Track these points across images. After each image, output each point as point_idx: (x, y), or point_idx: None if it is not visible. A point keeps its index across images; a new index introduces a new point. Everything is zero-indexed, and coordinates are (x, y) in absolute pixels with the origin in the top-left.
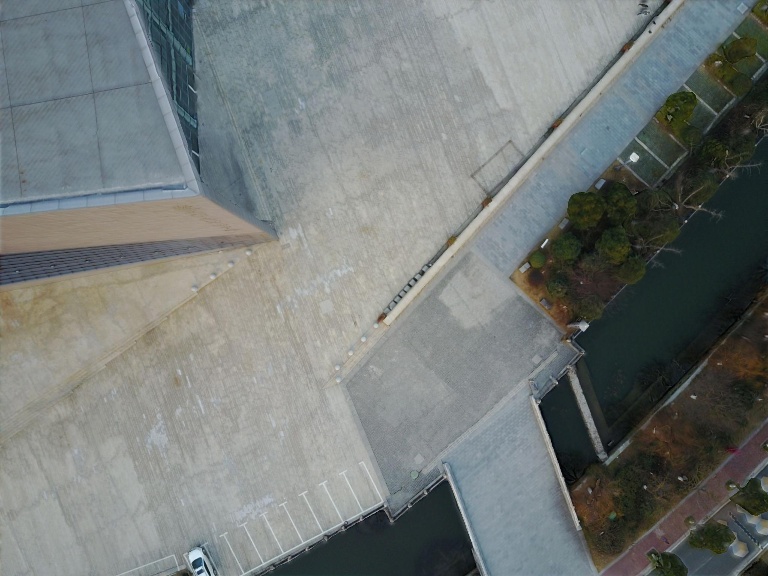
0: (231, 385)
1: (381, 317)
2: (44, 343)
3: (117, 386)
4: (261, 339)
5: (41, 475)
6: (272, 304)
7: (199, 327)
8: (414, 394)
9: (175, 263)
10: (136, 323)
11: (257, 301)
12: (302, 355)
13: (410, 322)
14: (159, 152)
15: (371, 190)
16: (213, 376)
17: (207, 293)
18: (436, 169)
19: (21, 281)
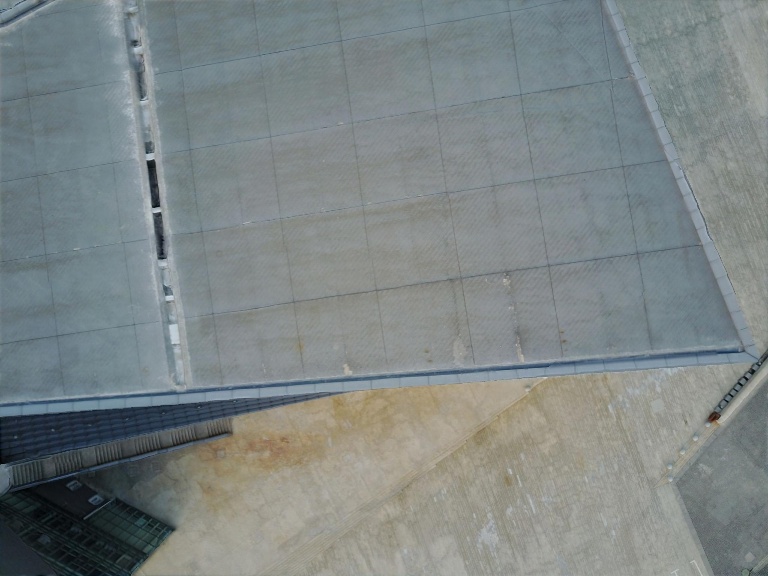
0: (562, 484)
1: (715, 417)
2: (376, 443)
3: (447, 485)
4: (592, 438)
5: (370, 575)
6: (604, 403)
7: (530, 426)
8: (744, 492)
9: None
10: (468, 423)
11: (589, 400)
12: (634, 454)
13: (738, 420)
14: (712, 315)
15: None
16: (544, 475)
17: (538, 392)
18: (763, 268)
19: None
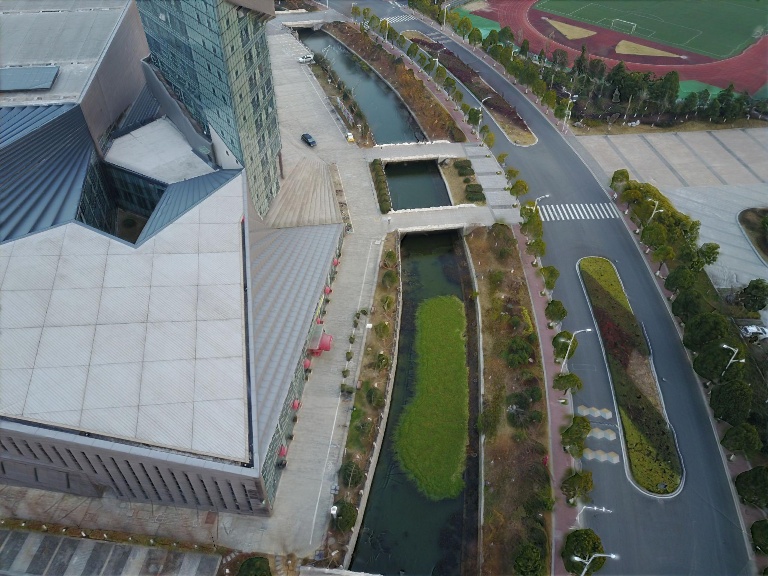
0: None
1: None
2: None
3: None
4: None
5: None
6: None
7: None
8: None
9: None
10: None
11: None
12: None
13: None
14: None
15: None
16: None
17: None
18: None
19: None
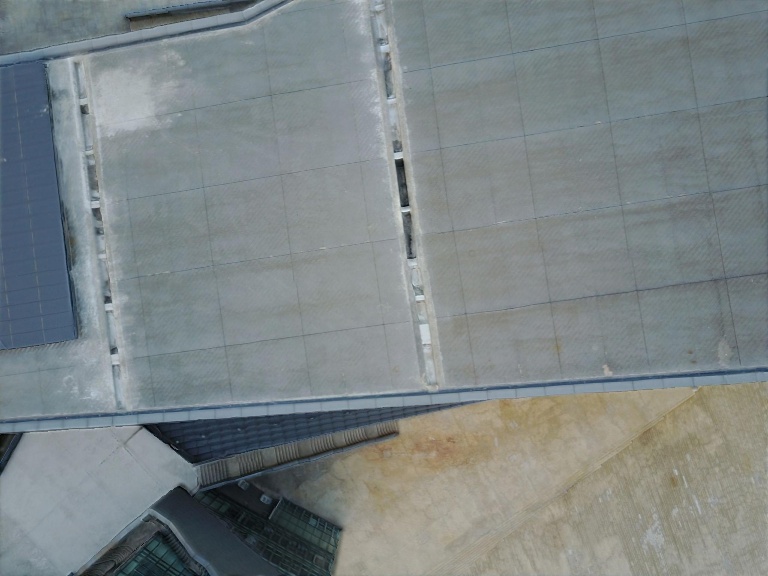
0: (728, 485)
1: None
2: (543, 444)
3: (612, 486)
4: (759, 439)
5: (534, 575)
6: None
7: (696, 427)
8: None
9: None
10: (635, 423)
11: (756, 401)
12: None
13: None
14: None
15: None
16: (710, 476)
17: (704, 393)
18: None
19: None
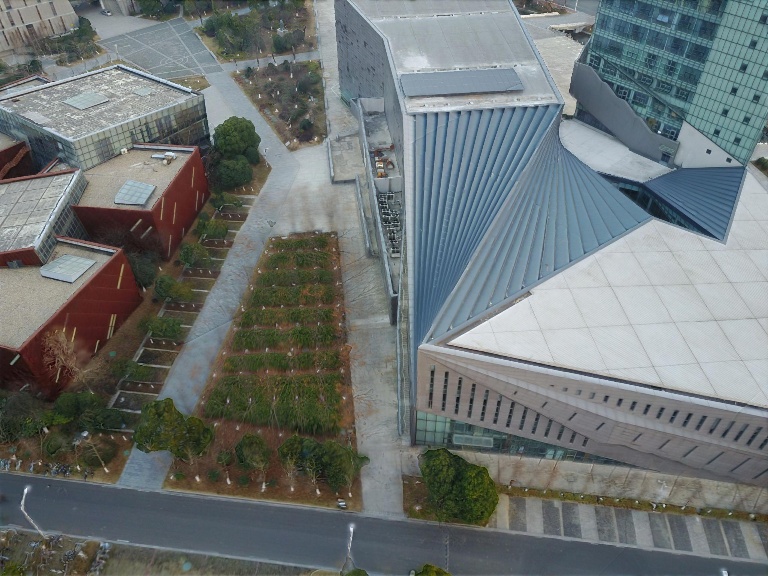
0: None
1: None
2: None
3: None
4: None
5: None
6: None
7: None
8: None
9: None
10: None
11: None
12: None
13: None
14: None
15: None
16: None
17: None
18: None
19: None
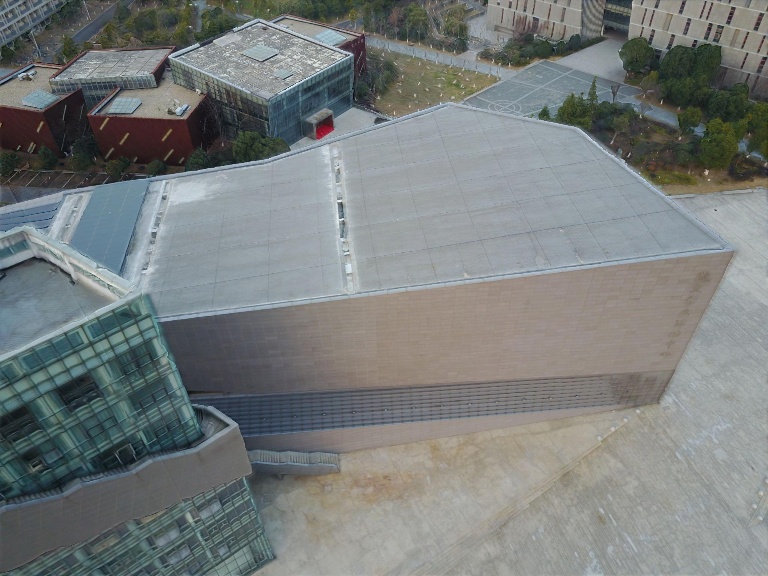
0: (656, 523)
1: None
2: (471, 482)
3: (543, 524)
4: (671, 481)
5: None
6: (671, 451)
7: (610, 471)
8: None
9: (577, 419)
10: (553, 465)
11: (657, 449)
12: (715, 495)
13: None
14: (695, 235)
15: (719, 371)
16: (636, 514)
17: (610, 443)
18: (764, 359)
19: (466, 417)
